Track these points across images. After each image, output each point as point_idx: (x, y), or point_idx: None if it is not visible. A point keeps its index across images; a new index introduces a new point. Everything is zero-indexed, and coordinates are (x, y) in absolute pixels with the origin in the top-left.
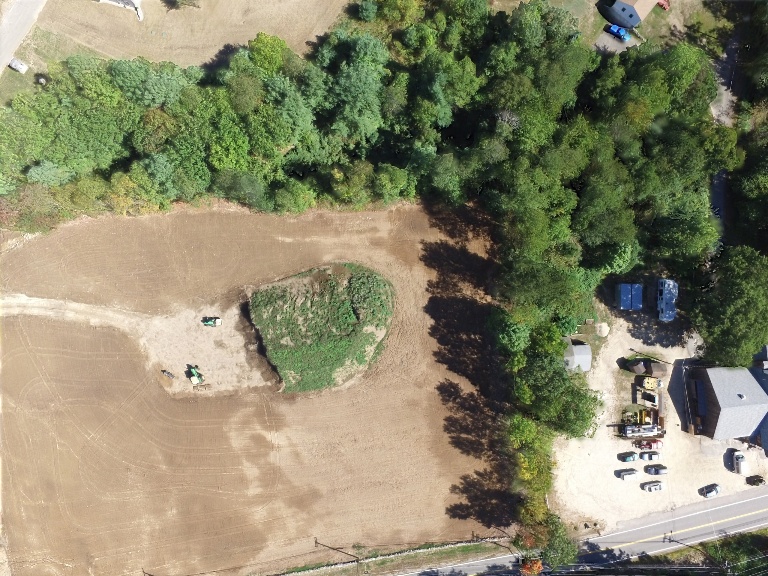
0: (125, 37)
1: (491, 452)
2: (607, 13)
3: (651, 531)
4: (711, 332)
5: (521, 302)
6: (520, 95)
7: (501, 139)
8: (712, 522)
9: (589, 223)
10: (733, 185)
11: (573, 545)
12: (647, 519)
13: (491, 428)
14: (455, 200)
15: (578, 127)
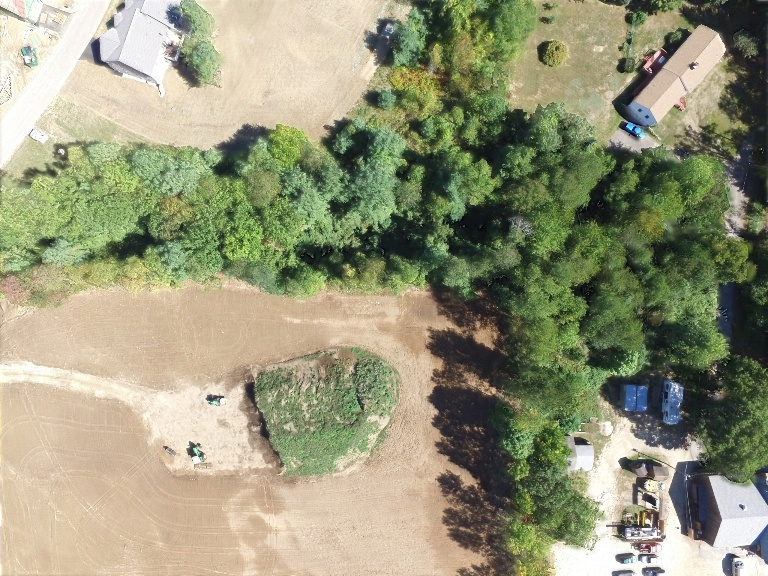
0: (145, 112)
1: (489, 547)
2: (623, 111)
3: None
4: (715, 448)
5: (526, 407)
6: (534, 200)
7: (513, 244)
8: None
9: (597, 332)
10: (742, 289)
11: None
12: None
13: (490, 523)
14: (465, 296)
15: (590, 235)
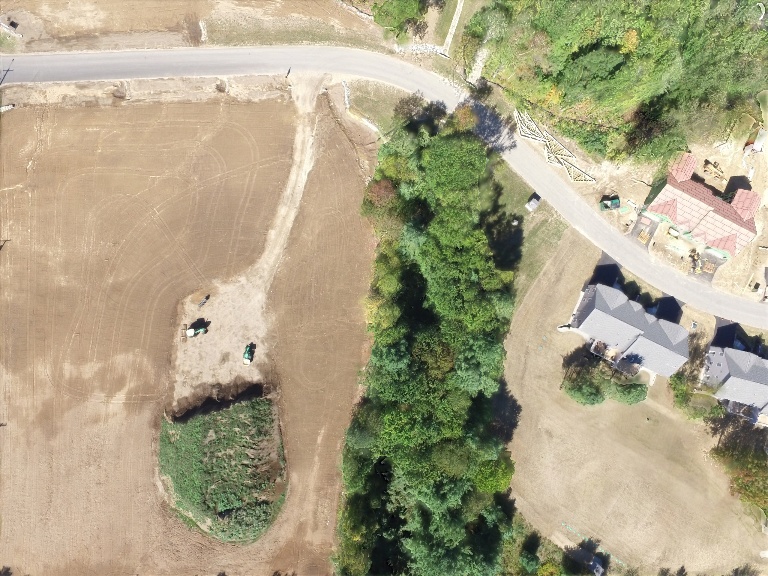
0: (545, 309)
1: None
2: None
3: None
4: None
5: None
6: None
7: None
8: None
9: None
10: None
11: None
12: None
13: None
14: None
15: None
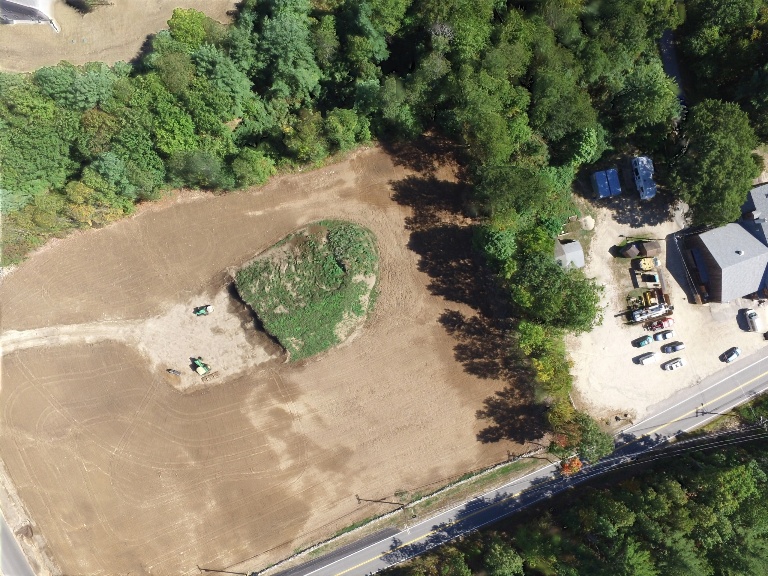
0: (48, 53)
1: (507, 370)
2: None
3: (682, 408)
4: (693, 193)
5: (498, 210)
6: (448, 5)
7: (439, 53)
8: (740, 385)
9: (546, 115)
10: (684, 48)
11: (608, 440)
12: (675, 398)
13: (501, 346)
14: (410, 129)
15: (513, 22)
